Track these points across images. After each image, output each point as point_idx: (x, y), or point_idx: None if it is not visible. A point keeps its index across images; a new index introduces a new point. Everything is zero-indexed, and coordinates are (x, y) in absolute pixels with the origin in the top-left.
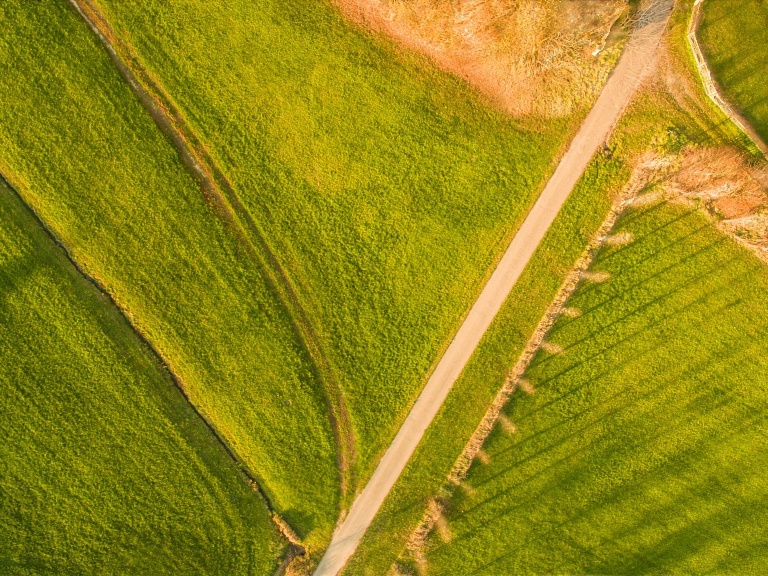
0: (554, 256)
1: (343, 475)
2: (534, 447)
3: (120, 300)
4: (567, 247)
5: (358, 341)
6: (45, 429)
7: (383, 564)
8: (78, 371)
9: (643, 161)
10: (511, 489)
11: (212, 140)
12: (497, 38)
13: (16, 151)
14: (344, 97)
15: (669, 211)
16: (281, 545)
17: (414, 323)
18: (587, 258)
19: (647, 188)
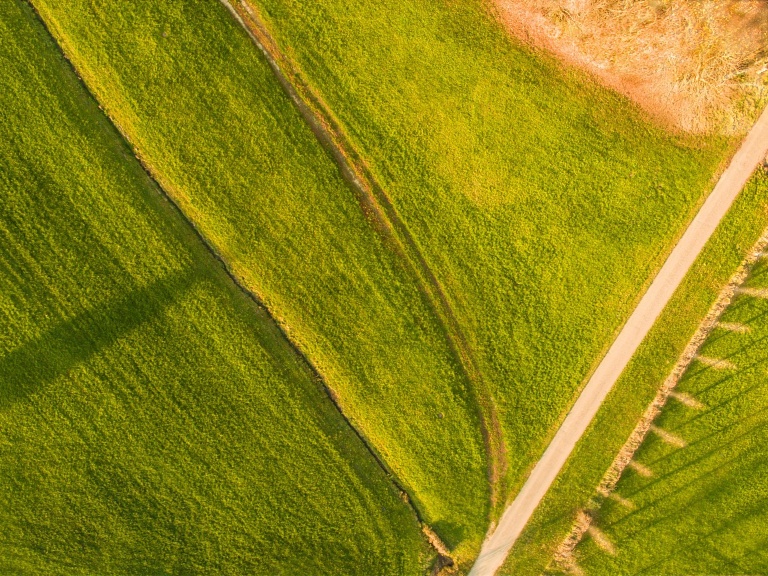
0: (710, 271)
1: (493, 487)
2: (682, 459)
3: (277, 313)
4: (723, 262)
5: (511, 354)
6: (200, 441)
7: (530, 575)
8: (234, 384)
9: None
10: (659, 501)
11: (372, 155)
12: (664, 56)
13: (178, 165)
14: (505, 113)
15: None
16: (430, 556)
17: (568, 337)
18: (743, 273)
19: None
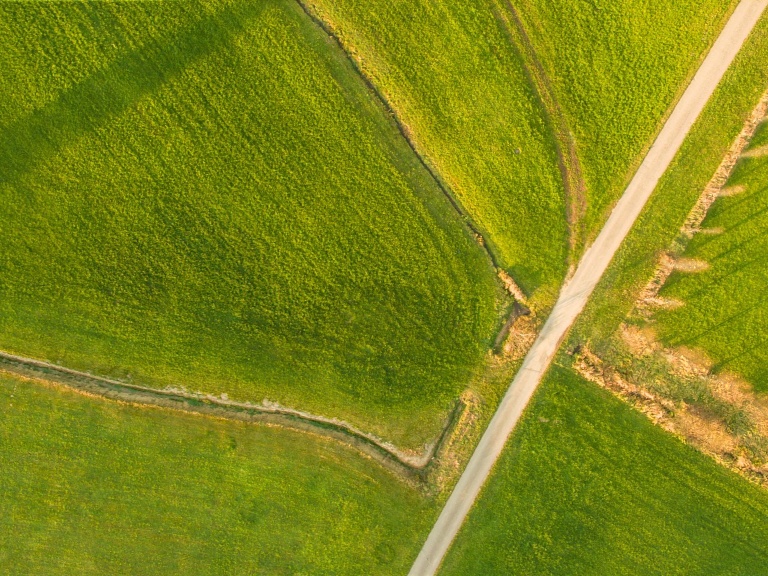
0: None
1: (572, 228)
2: None
3: (348, 43)
4: None
5: (591, 85)
6: (270, 178)
7: (611, 323)
8: (304, 118)
9: None
10: (746, 243)
11: None
12: None
13: None
14: None
15: None
16: (506, 303)
17: (650, 64)
18: None
19: None
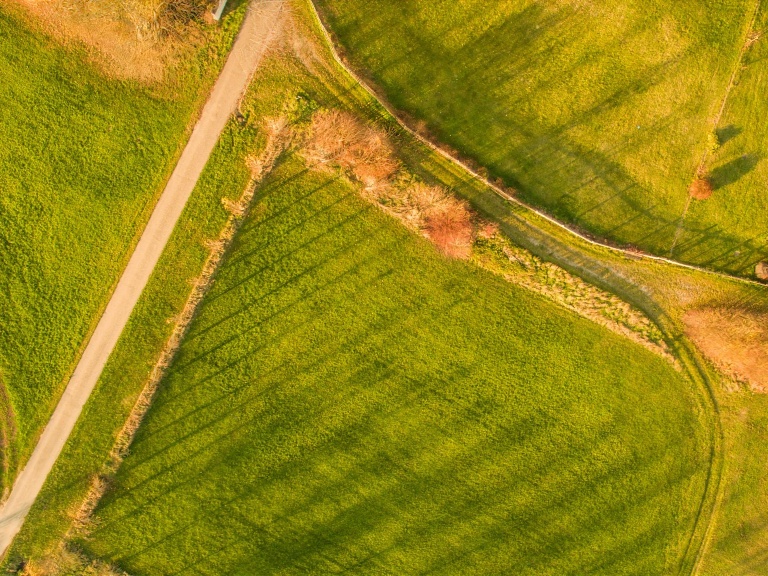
0: (198, 227)
1: (4, 452)
2: (196, 422)
3: None
4: (210, 217)
5: (11, 316)
6: None
7: (51, 542)
8: None
9: (277, 128)
10: (176, 465)
11: None
12: (115, 3)
13: None
14: None
15: (312, 179)
16: None
17: (65, 297)
18: (230, 228)
19: (286, 156)
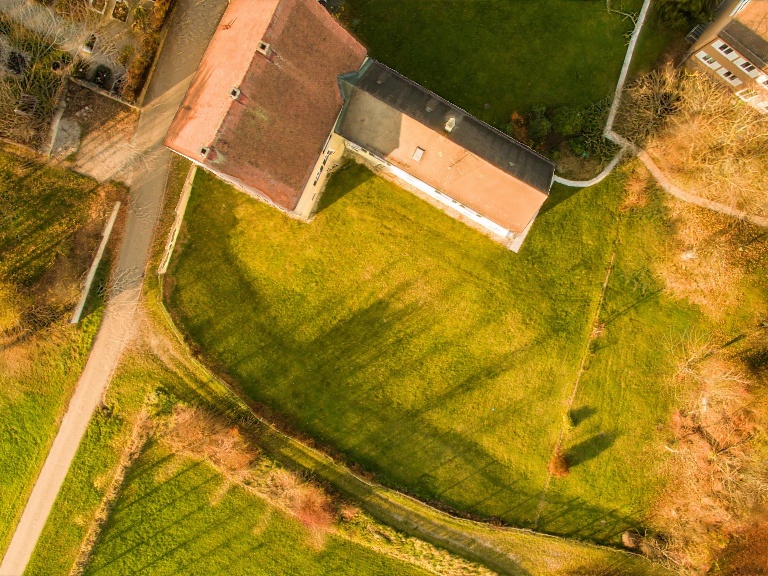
0: (73, 508)
1: None
2: None
3: None
4: (84, 500)
5: None
6: None
7: None
8: None
9: (141, 418)
10: None
11: None
12: None
13: None
14: None
15: (179, 462)
16: None
17: None
18: (104, 510)
19: (152, 442)
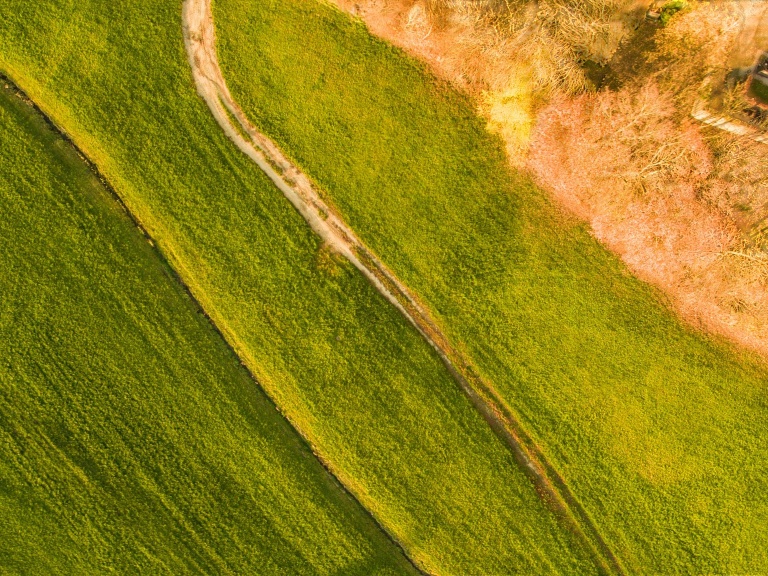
0: None
1: None
2: None
3: None
4: None
5: None
6: None
7: None
8: None
9: None
10: None
11: (545, 439)
12: None
13: (355, 460)
14: (679, 396)
15: None
16: None
17: None
18: None
19: None
